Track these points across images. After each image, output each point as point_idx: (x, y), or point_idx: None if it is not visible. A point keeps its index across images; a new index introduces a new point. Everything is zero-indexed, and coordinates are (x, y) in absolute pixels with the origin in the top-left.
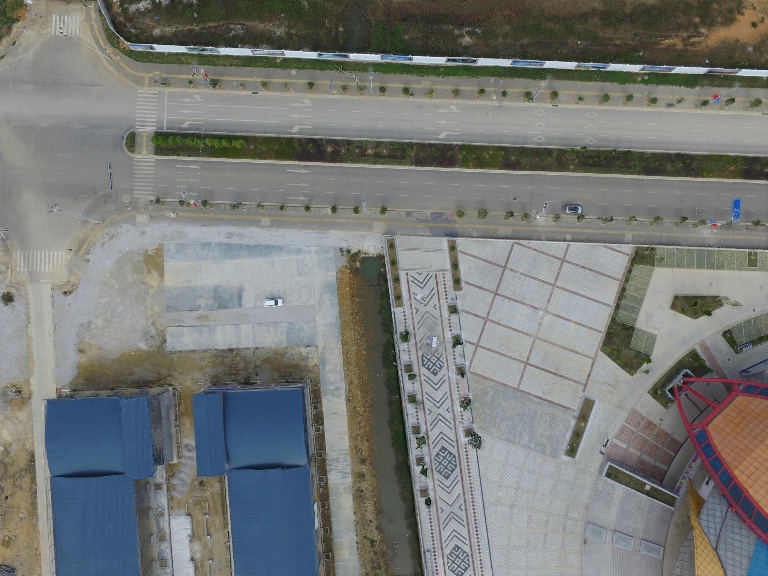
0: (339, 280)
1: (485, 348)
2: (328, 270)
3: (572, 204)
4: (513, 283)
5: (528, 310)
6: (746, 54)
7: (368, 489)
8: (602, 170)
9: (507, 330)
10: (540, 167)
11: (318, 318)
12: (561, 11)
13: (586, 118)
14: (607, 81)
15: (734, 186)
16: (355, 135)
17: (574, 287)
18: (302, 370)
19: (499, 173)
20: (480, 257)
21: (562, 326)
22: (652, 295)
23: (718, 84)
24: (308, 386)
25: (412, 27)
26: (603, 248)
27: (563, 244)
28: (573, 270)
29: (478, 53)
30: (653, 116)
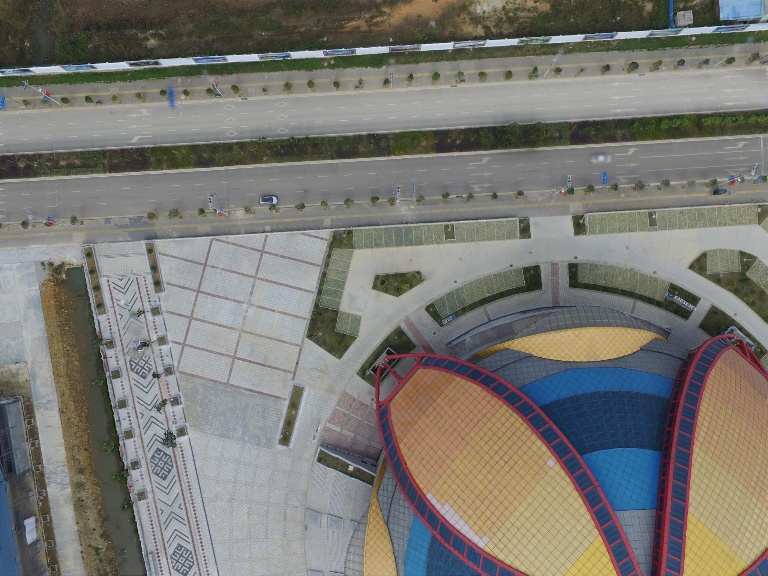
0: (43, 294)
1: (192, 346)
2: (31, 285)
3: (267, 195)
4: (214, 279)
5: (231, 304)
6: (428, 29)
7: (89, 498)
8: (294, 158)
9: (212, 326)
10: (234, 161)
11: (25, 334)
12: (245, 4)
13: (276, 108)
14: (293, 69)
15: (428, 161)
16: (47, 148)
17: (275, 277)
18: (13, 387)
19: (194, 171)
20: (180, 257)
21: (266, 317)
22: (353, 277)
23: (404, 61)
24: (20, 402)
25: (94, 35)
26: (301, 235)
27: (261, 236)
28: (273, 260)
29: (162, 54)
30: (342, 99)
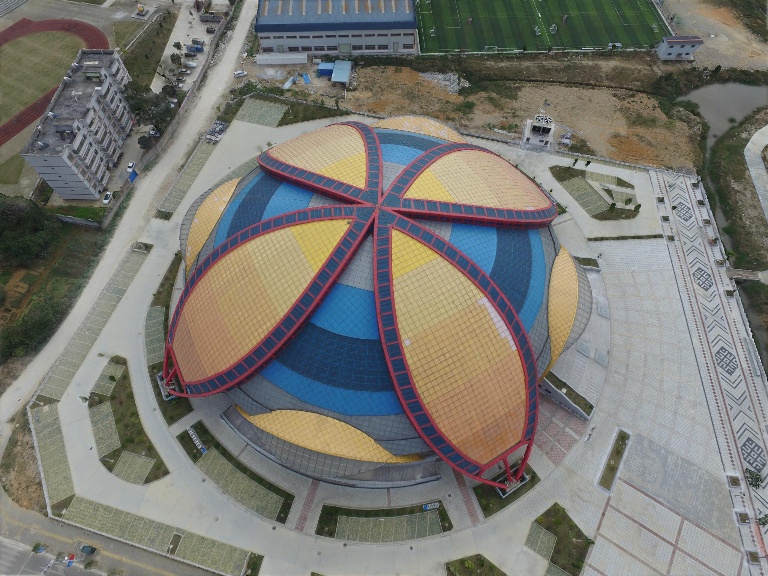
0: None
1: None
2: None
3: None
4: None
5: None
6: None
7: None
8: None
9: None
10: None
11: None
12: None
13: None
14: None
15: None
16: None
17: None
18: None
19: None
20: None
21: None
22: None
23: None
24: None
25: None
26: None
27: None
28: None
29: None
30: None
